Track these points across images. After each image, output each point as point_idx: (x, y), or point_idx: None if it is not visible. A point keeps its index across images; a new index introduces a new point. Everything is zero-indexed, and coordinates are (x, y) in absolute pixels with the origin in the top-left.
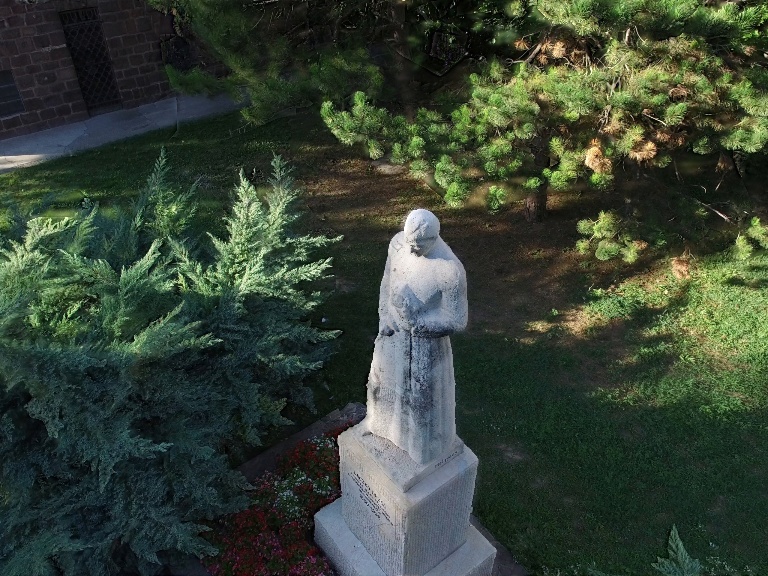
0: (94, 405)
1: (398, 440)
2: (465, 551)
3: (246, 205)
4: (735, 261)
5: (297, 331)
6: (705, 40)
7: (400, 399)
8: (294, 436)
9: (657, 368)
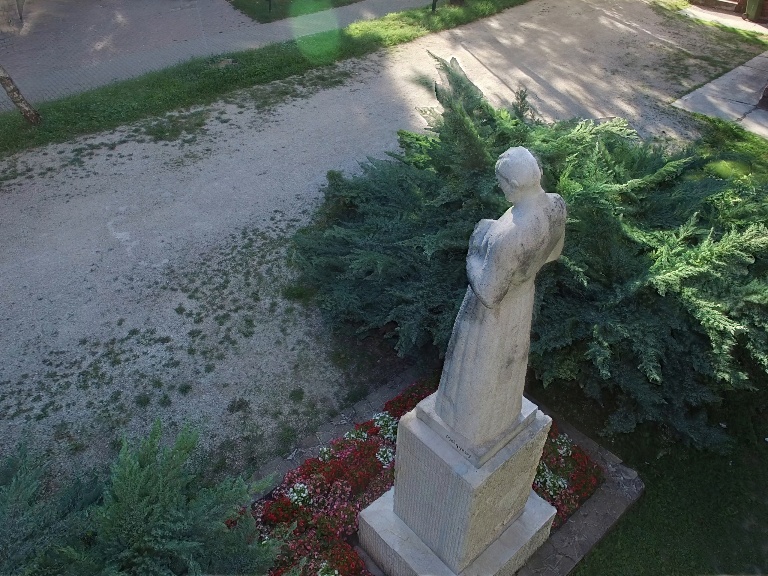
0: (470, 221)
1: None
2: (446, 573)
3: (767, 233)
4: None
5: None
6: None
7: None
8: (569, 424)
9: None
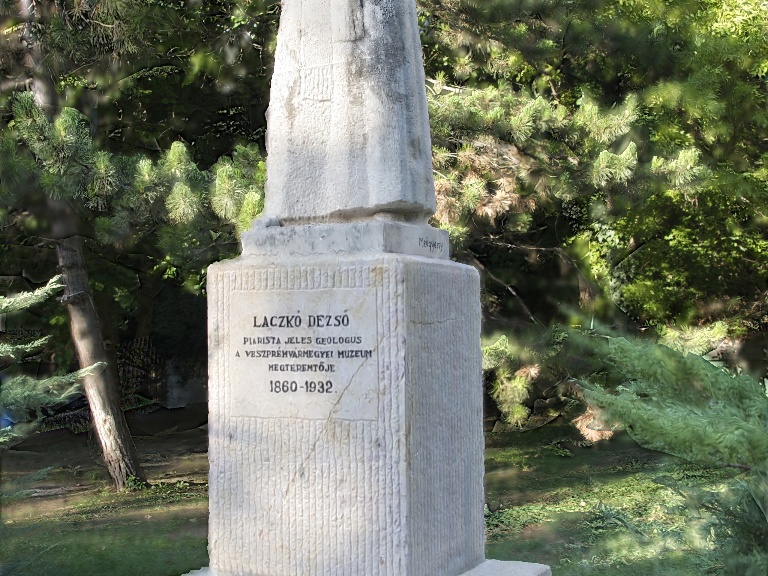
0: None
1: (345, 185)
2: (493, 567)
3: None
4: (652, 478)
5: (4, 385)
6: (523, 57)
7: (345, 71)
8: None
9: (632, 538)
